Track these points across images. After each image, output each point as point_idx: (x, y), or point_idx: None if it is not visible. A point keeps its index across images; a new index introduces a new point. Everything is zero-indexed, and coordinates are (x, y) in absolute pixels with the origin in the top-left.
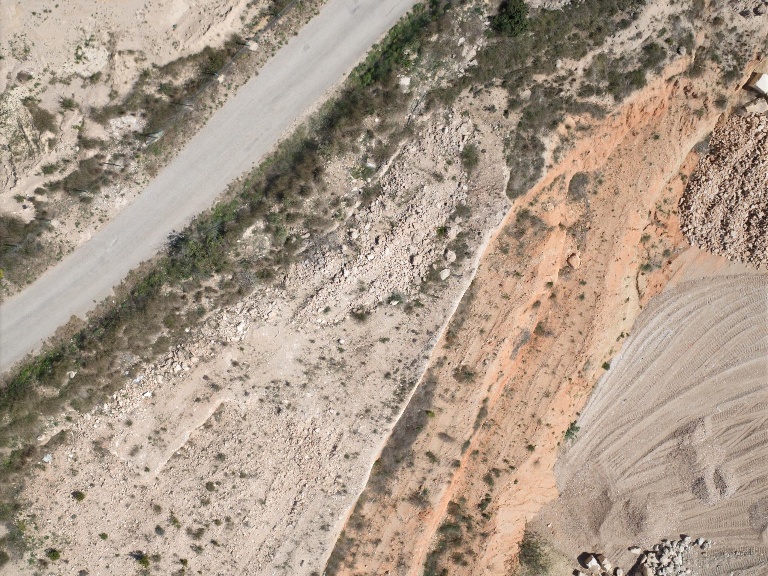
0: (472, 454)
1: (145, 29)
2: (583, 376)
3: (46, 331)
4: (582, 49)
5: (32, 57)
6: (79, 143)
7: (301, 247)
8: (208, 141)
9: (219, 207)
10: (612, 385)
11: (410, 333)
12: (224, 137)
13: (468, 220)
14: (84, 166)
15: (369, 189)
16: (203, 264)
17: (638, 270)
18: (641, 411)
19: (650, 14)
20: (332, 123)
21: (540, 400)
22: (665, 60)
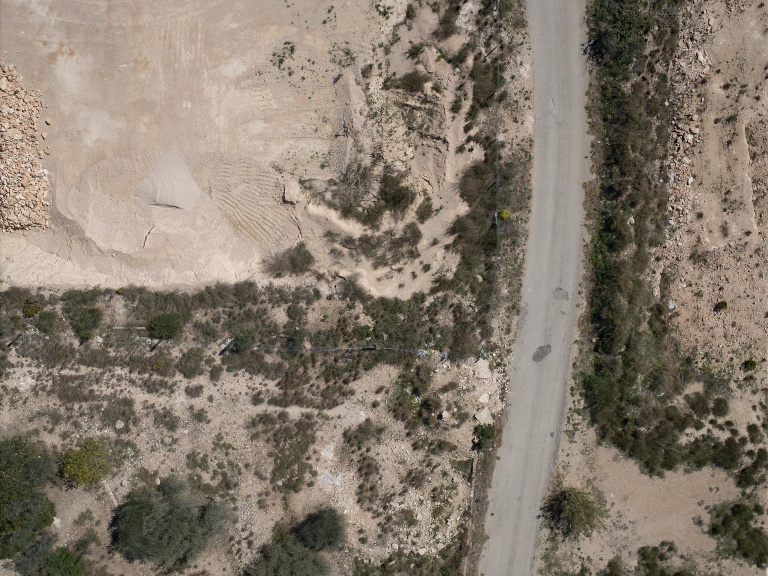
0: None
1: None
2: None
3: (578, 216)
4: None
5: (356, 52)
6: (454, 65)
7: None
8: None
9: None
10: None
11: None
12: None
13: None
14: (477, 74)
15: None
16: (634, 36)
17: None
18: None
19: None
20: None
21: None
22: None
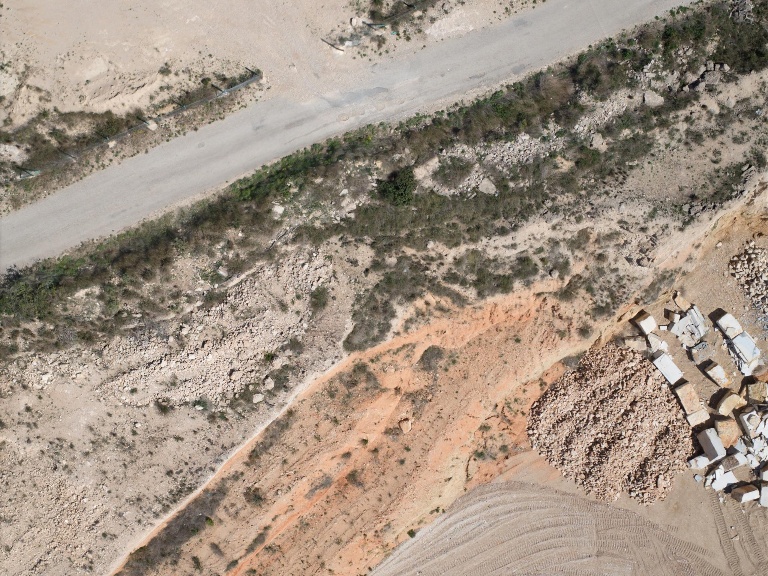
0: (249, 572)
1: (60, 74)
2: (380, 536)
3: None
4: (456, 239)
5: None
6: None
7: (130, 324)
8: (79, 196)
9: (66, 259)
10: (413, 553)
11: (206, 441)
12: (95, 197)
13: (298, 356)
14: None
15: (213, 294)
16: (27, 307)
17: (471, 454)
18: None
19: (530, 231)
20: (197, 222)
21: (330, 544)
22: (536, 276)
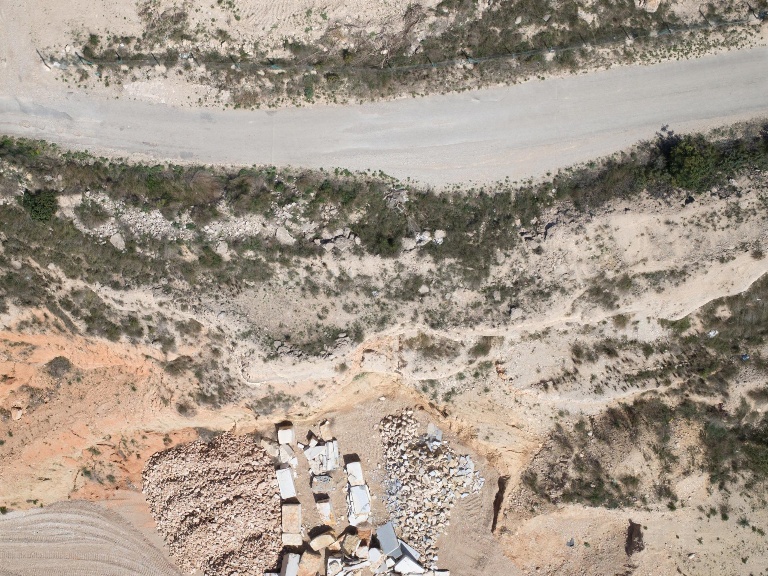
0: None
1: None
2: None
3: None
4: (75, 273)
5: None
6: None
7: None
8: None
9: None
10: (1, 528)
11: None
12: None
13: None
14: None
15: None
16: None
17: (81, 469)
18: (2, 567)
19: (138, 297)
20: None
21: None
22: (141, 339)
